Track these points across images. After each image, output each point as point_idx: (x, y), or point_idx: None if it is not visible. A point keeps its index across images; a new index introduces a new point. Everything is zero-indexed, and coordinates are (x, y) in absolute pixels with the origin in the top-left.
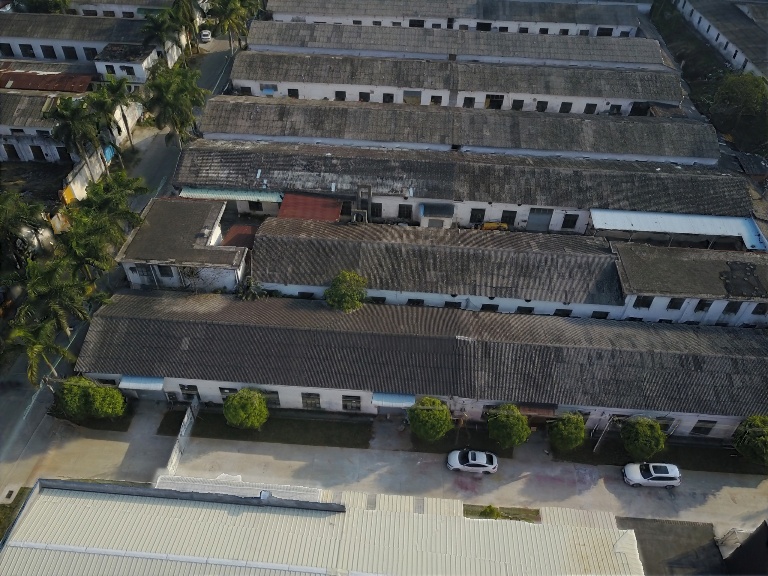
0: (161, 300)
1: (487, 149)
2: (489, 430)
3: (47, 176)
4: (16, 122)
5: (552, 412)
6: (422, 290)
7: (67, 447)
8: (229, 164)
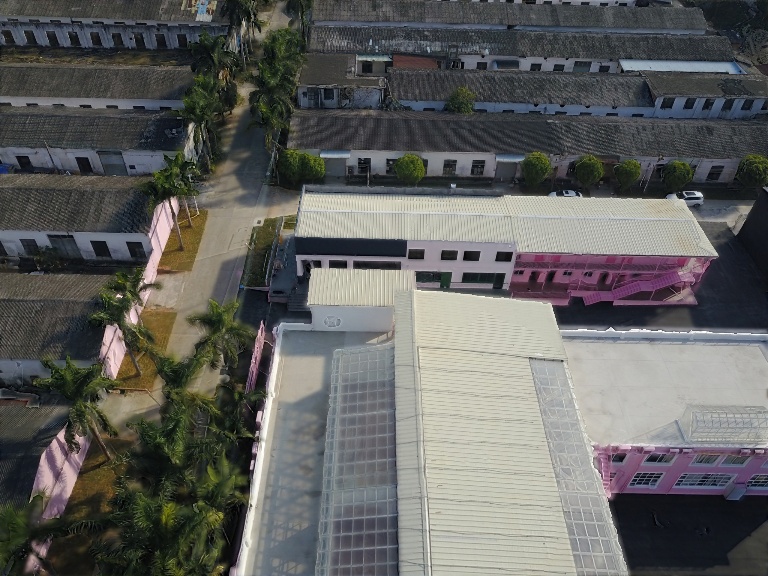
0: (331, 111)
1: (534, 28)
2: (577, 172)
3: (193, 58)
4: (163, 18)
5: (617, 161)
6: (514, 101)
7: (286, 200)
8: (346, 36)
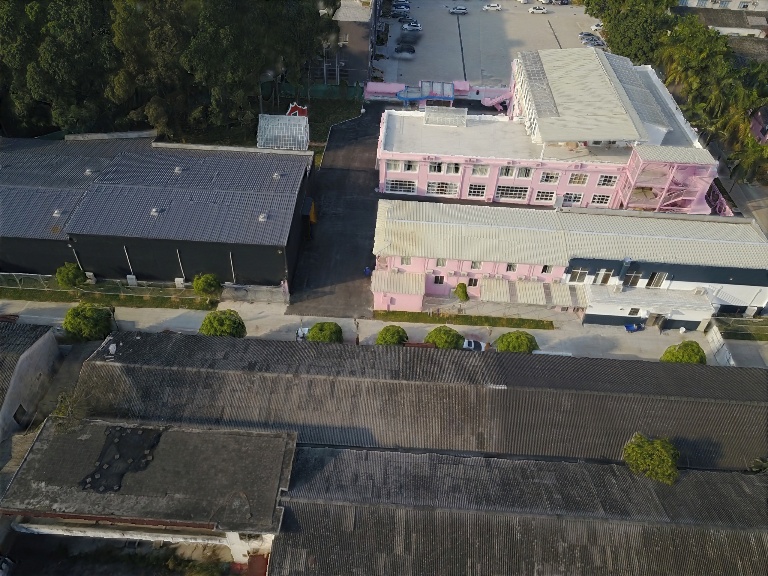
0: None
1: None
2: None
3: None
4: None
5: (406, 345)
6: None
7: None
8: None
